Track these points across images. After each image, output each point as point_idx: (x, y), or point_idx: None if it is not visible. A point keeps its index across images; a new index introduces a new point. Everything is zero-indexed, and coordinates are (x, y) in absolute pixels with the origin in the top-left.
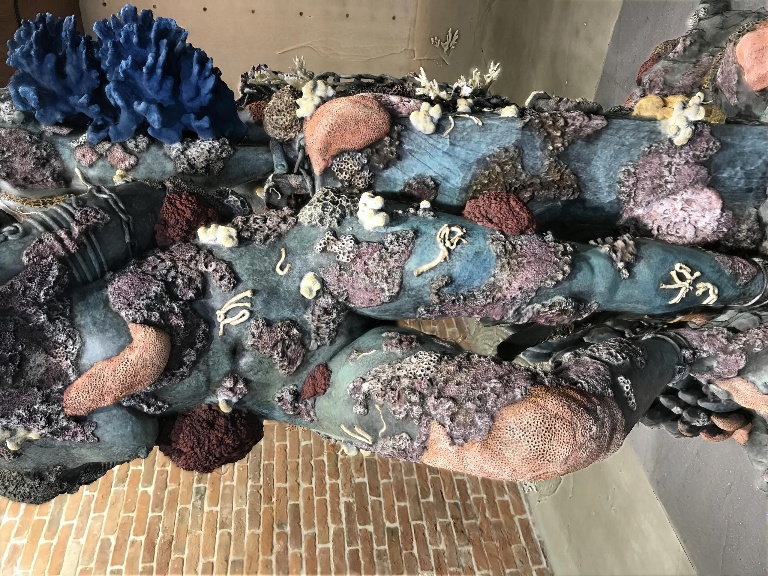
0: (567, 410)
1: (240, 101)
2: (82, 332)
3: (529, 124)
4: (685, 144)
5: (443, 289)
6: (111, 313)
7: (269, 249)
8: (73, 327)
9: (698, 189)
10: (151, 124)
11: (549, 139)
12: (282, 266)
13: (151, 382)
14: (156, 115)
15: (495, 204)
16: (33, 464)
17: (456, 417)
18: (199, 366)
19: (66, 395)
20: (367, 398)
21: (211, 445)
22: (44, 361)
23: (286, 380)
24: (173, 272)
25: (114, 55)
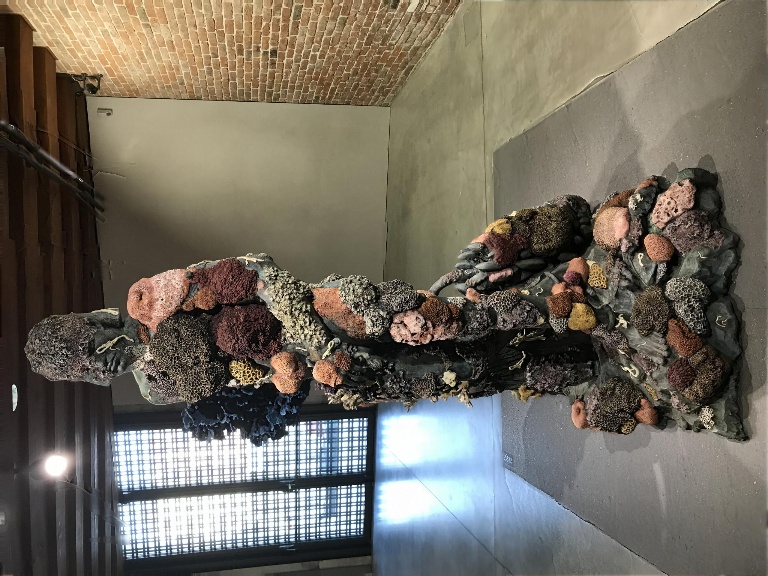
0: None
1: (313, 365)
2: None
3: None
4: None
5: None
6: None
7: None
8: None
9: None
10: None
11: None
12: None
13: None
14: None
15: None
16: None
17: None
18: None
19: None
20: None
21: None
22: None
23: None
24: None
25: None
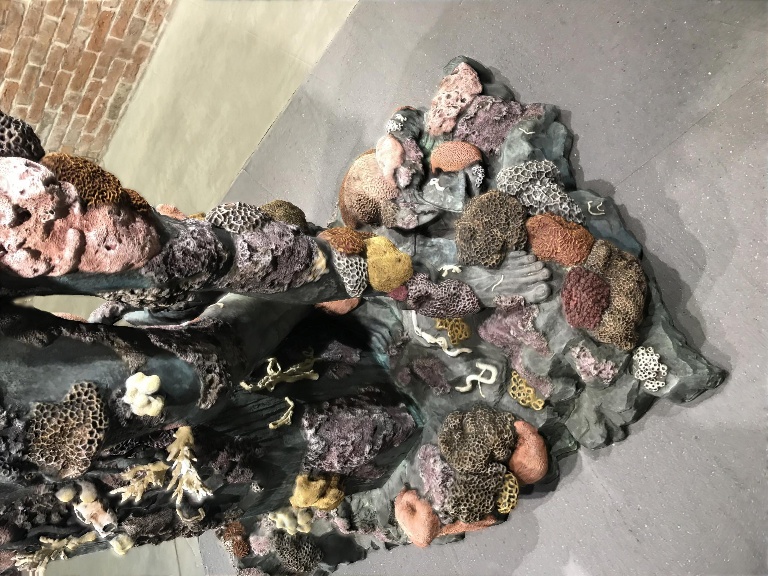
0: None
1: None
2: None
3: None
4: None
5: None
6: None
7: None
8: None
9: None
10: None
11: None
12: None
13: None
14: None
15: None
16: None
17: None
18: None
19: None
20: None
21: None
22: None
23: None
24: None
25: None
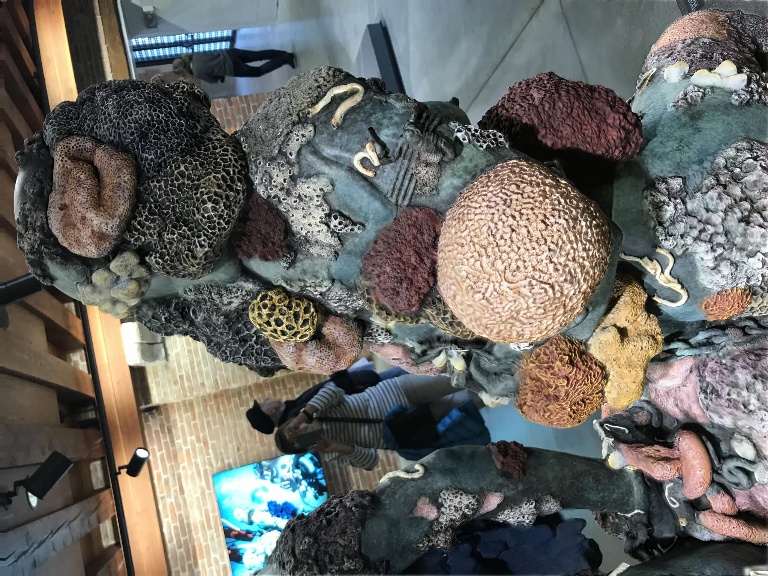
0: None
1: None
2: None
3: None
4: None
5: None
6: None
7: None
8: None
9: None
10: None
11: None
12: None
13: None
14: None
15: None
16: None
17: None
18: None
19: None
20: None
21: None
22: None
23: None
24: None
25: None
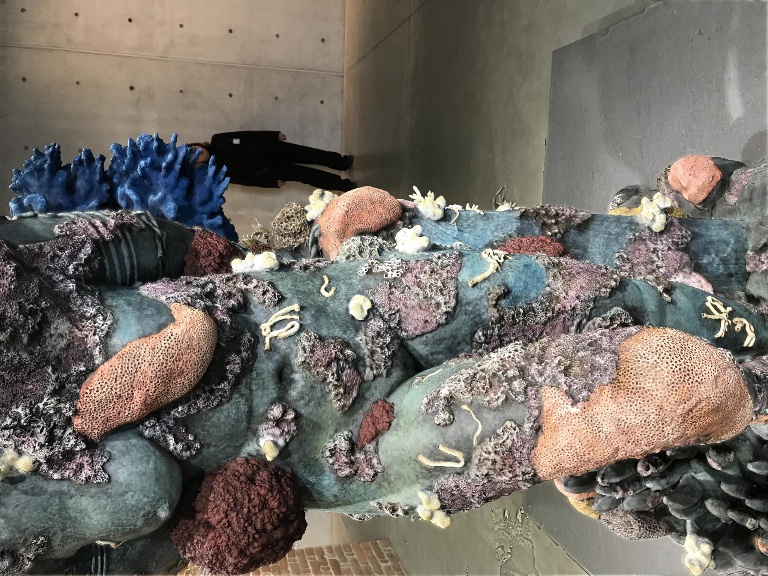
0: (692, 337)
1: None
2: (114, 311)
3: (525, 214)
4: (662, 232)
5: (500, 302)
6: (148, 298)
7: (310, 276)
8: (103, 306)
9: (687, 273)
10: (166, 214)
11: (545, 227)
12: (327, 289)
13: (191, 382)
14: (173, 204)
15: (526, 238)
16: (4, 533)
17: (570, 371)
18: (241, 388)
19: (84, 388)
20: (449, 403)
21: (252, 507)
22: (67, 332)
23: (339, 422)
24: (211, 285)
25: (132, 161)
